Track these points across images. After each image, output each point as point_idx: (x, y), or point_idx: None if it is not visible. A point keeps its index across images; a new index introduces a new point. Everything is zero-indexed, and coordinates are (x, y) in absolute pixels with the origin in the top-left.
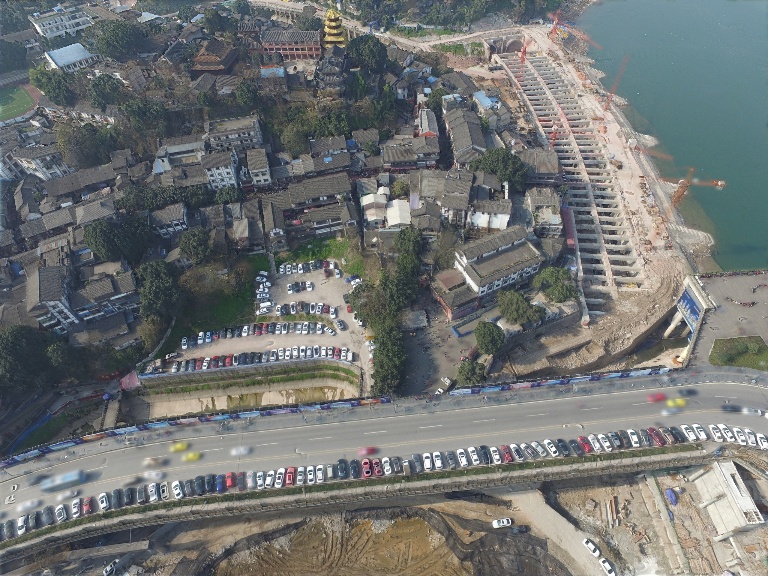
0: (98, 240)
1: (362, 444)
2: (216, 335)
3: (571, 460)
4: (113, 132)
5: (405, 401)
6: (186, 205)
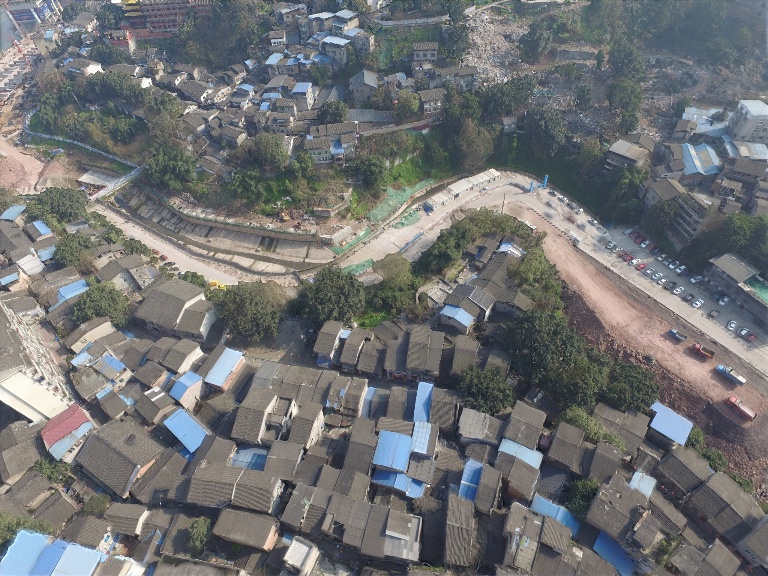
0: None
1: None
2: None
3: None
4: None
5: None
6: None
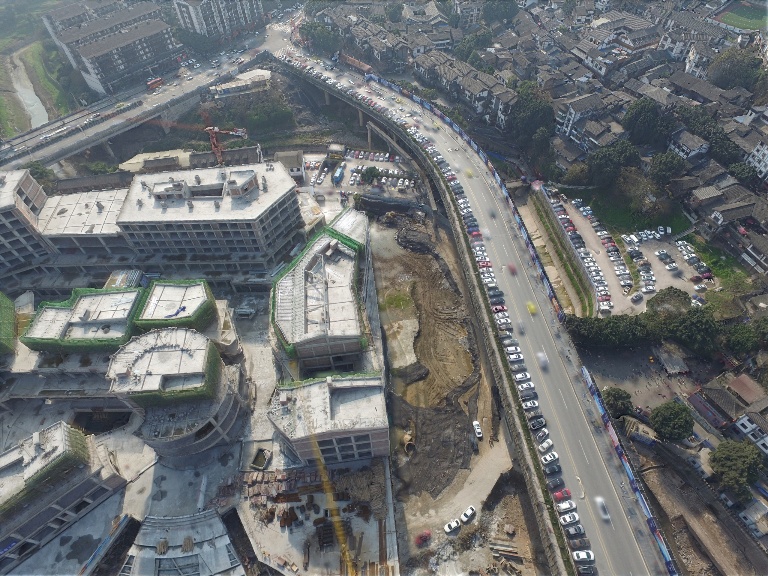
0: (635, 108)
1: (518, 305)
2: (591, 216)
3: (541, 476)
4: (762, 75)
5: (565, 333)
6: (710, 148)
